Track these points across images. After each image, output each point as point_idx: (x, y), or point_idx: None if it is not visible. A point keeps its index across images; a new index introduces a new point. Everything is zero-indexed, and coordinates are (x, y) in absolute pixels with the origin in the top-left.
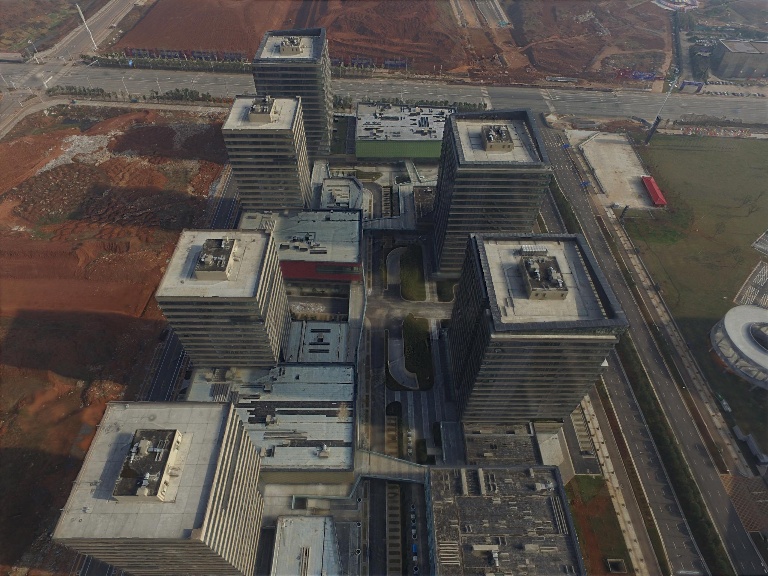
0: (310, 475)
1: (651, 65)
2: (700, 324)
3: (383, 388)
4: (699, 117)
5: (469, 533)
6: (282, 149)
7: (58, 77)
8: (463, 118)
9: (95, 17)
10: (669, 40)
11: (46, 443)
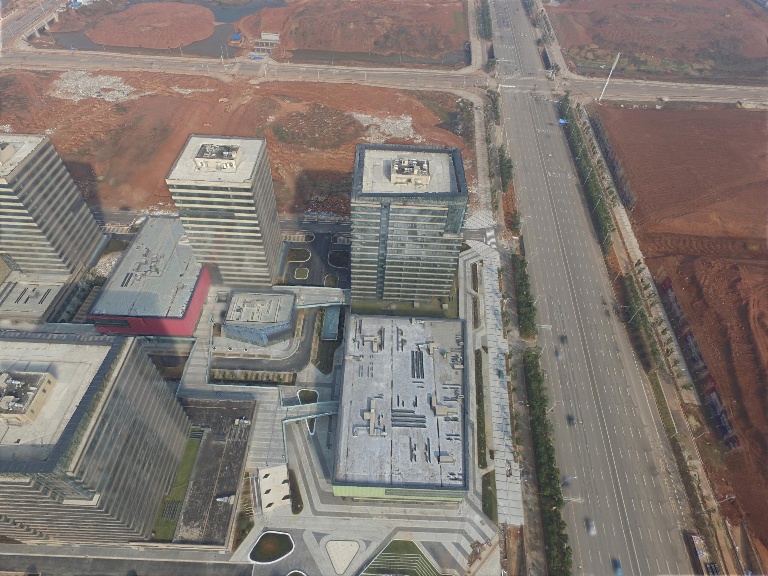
0: None
1: None
2: None
3: None
4: None
5: None
6: None
7: (526, 92)
8: (114, 360)
9: (680, 85)
10: None
11: None
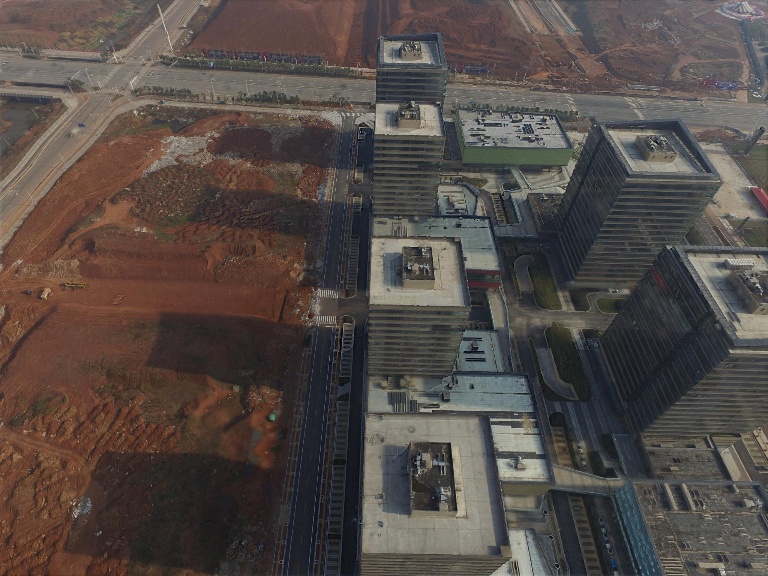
0: (507, 487)
1: (731, 75)
2: None
3: (541, 398)
4: None
5: (689, 550)
6: (430, 155)
7: (140, 77)
8: (611, 127)
9: None
10: (742, 50)
11: (223, 449)
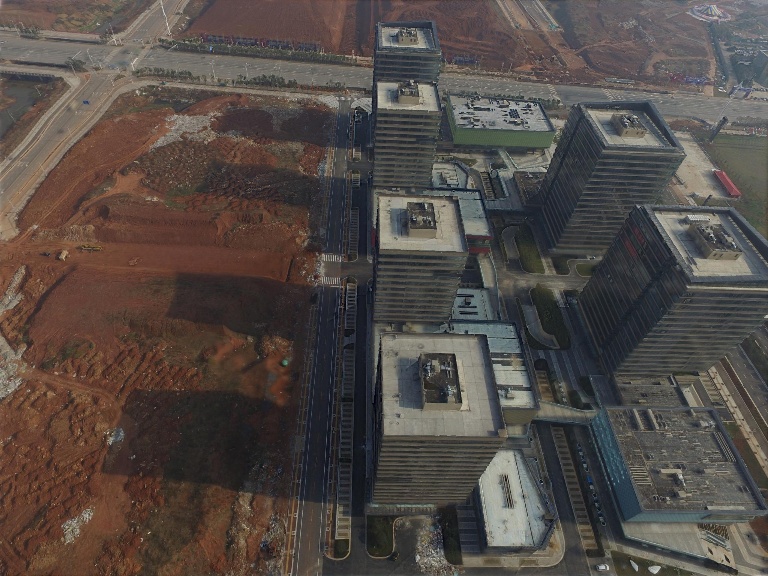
0: None
1: (699, 71)
2: None
3: (527, 347)
4: (754, 119)
5: (653, 460)
6: (427, 129)
7: (140, 59)
8: (590, 107)
9: (159, 3)
10: (710, 49)
11: (242, 387)
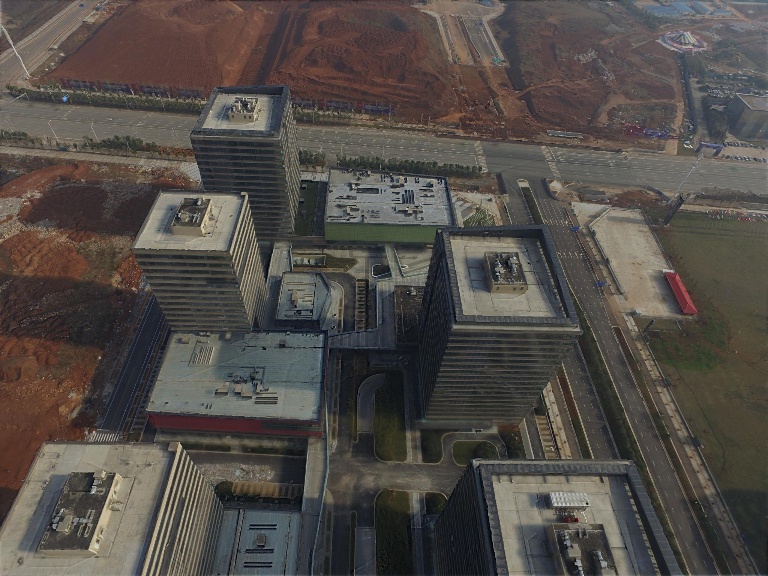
0: None
1: (662, 119)
2: (755, 502)
3: None
4: (723, 191)
5: None
6: (217, 271)
7: None
8: (459, 234)
9: (34, 35)
10: (679, 88)
11: None
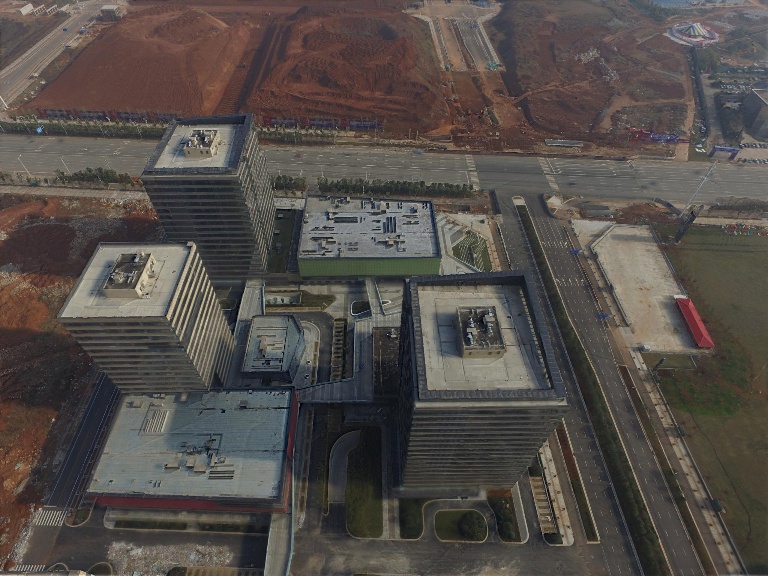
0: None
1: (671, 121)
2: None
3: None
4: (740, 201)
5: None
6: (158, 336)
7: None
8: (430, 283)
9: (16, 63)
10: (689, 86)
11: None
